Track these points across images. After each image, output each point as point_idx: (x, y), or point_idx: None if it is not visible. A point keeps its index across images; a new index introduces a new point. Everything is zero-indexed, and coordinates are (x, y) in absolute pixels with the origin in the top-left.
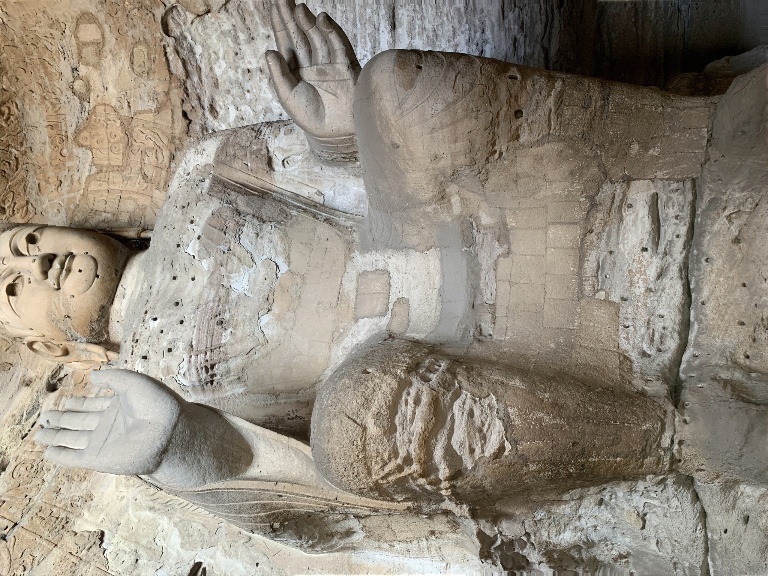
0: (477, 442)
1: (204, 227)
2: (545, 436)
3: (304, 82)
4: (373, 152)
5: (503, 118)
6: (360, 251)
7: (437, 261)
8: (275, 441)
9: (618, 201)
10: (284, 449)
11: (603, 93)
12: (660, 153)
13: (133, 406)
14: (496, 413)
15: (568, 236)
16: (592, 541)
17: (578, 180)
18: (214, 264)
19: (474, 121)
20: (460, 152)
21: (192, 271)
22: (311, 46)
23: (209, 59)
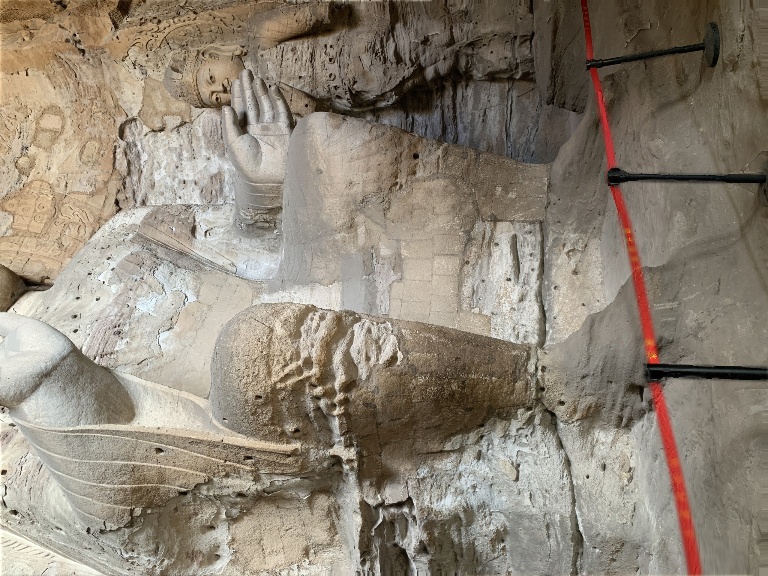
0: (373, 351)
1: (120, 262)
2: (432, 350)
3: (249, 134)
4: (299, 179)
5: (405, 157)
6: (268, 293)
7: (338, 294)
8: (165, 394)
9: (488, 238)
10: (172, 403)
11: (476, 152)
12: (516, 197)
13: (21, 339)
14: (391, 332)
15: (450, 266)
16: (471, 508)
17: (458, 215)
18: (123, 288)
19: (383, 156)
20: (370, 180)
21: (98, 293)
22: (260, 111)
23: (152, 166)
